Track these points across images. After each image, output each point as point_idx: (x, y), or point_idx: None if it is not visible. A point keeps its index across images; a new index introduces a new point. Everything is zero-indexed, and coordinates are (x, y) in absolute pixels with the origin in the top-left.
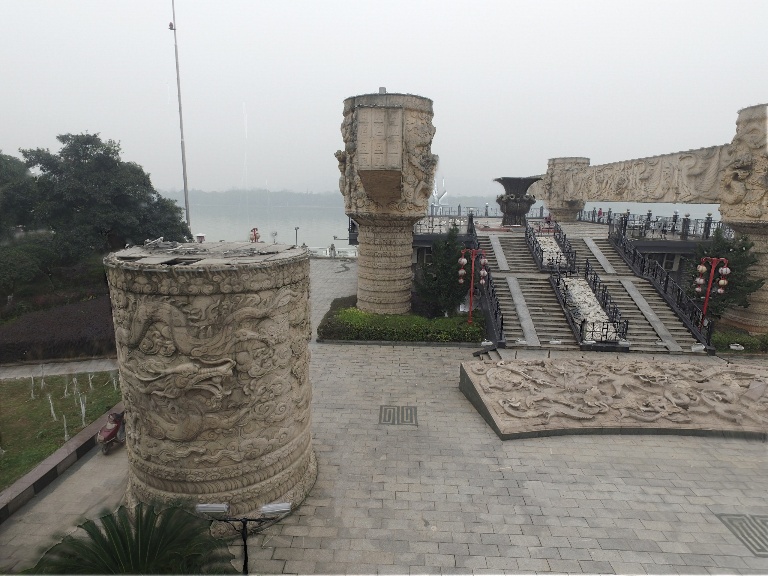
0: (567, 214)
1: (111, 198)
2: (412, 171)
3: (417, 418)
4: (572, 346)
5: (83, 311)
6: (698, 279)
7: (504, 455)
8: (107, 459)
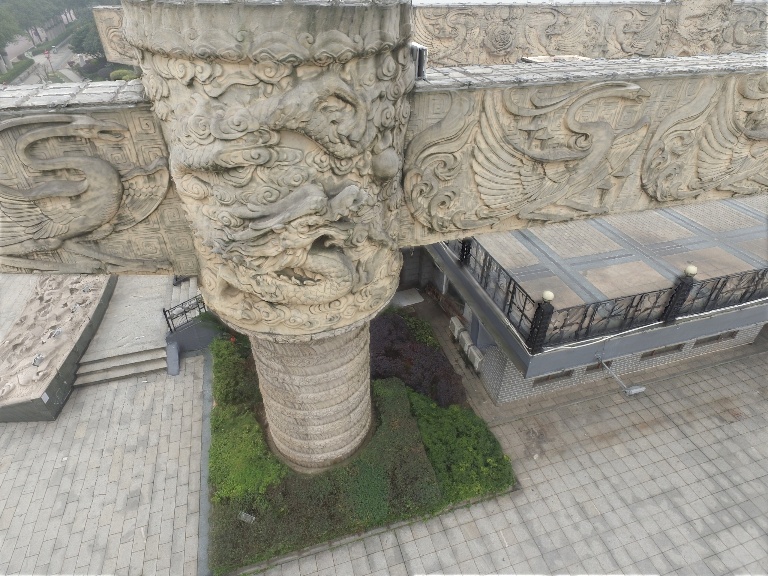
0: None
1: None
2: None
3: None
4: None
5: None
6: None
7: None
8: None
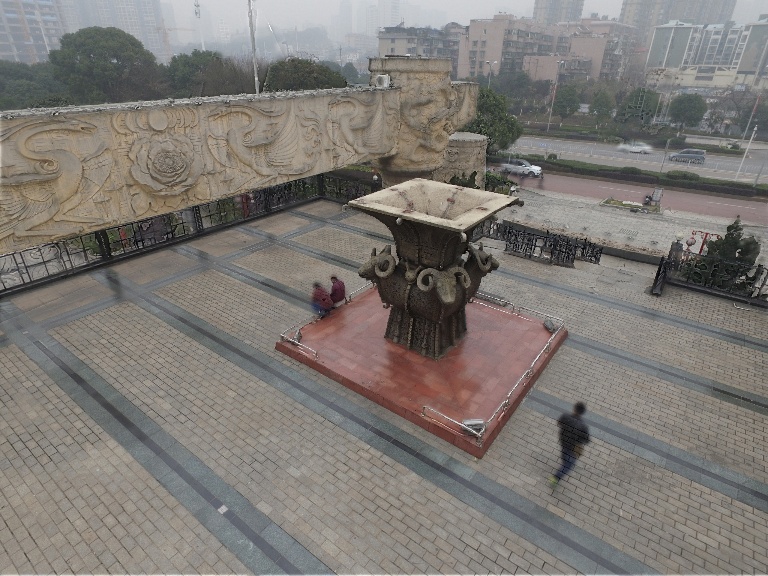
0: None
1: None
2: None
3: None
4: None
5: None
6: None
7: None
8: None
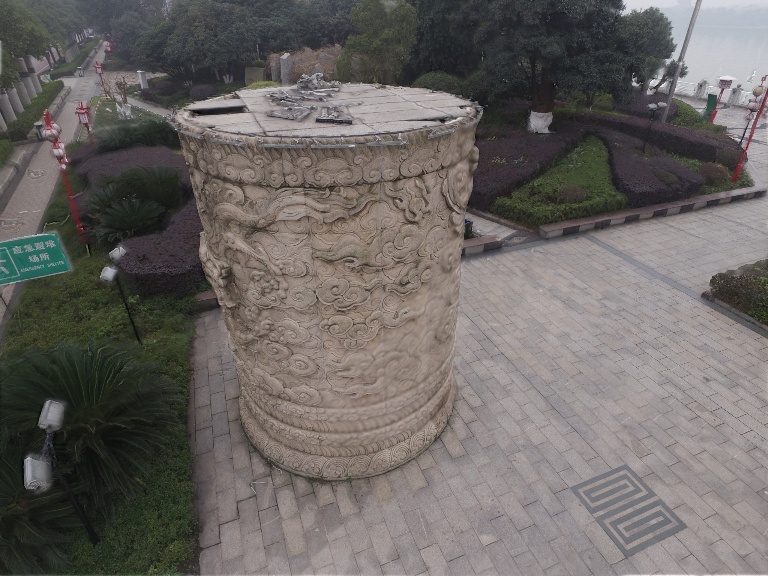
0: None
1: (542, 17)
2: None
3: (648, 546)
4: None
5: None
6: None
7: None
8: None
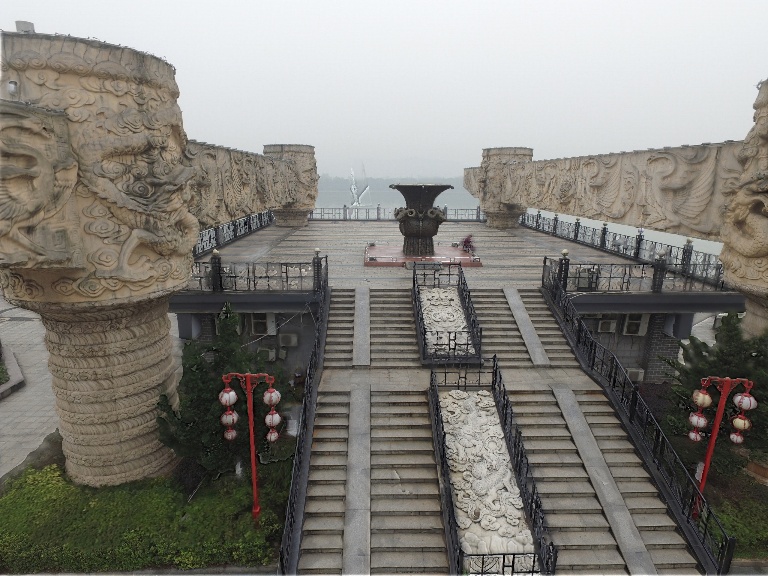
0: (506, 219)
1: None
2: (104, 210)
3: None
4: None
5: None
6: (695, 418)
7: None
8: None
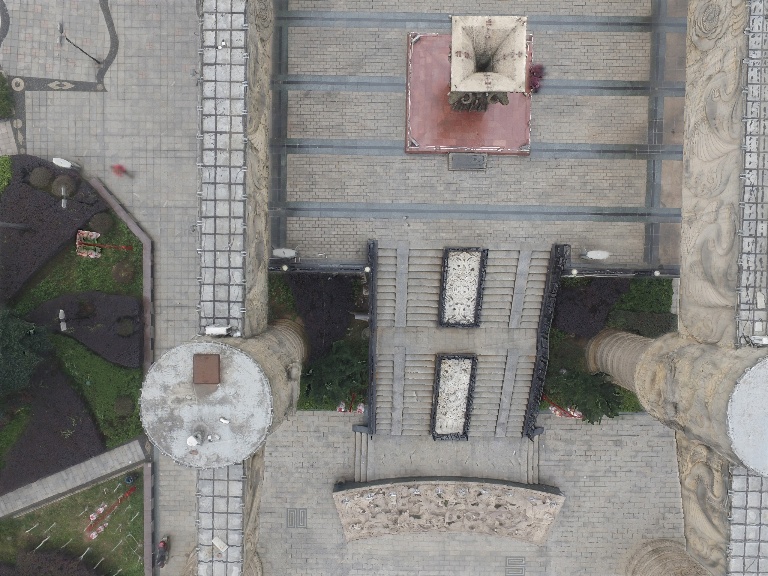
0: None
1: None
2: None
3: (307, 522)
4: (425, 433)
5: (41, 446)
6: (553, 412)
7: (346, 552)
8: (168, 566)
